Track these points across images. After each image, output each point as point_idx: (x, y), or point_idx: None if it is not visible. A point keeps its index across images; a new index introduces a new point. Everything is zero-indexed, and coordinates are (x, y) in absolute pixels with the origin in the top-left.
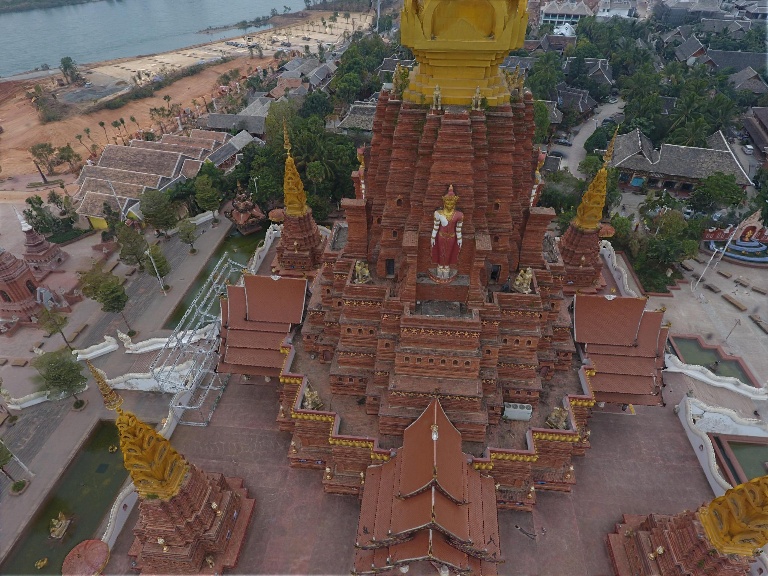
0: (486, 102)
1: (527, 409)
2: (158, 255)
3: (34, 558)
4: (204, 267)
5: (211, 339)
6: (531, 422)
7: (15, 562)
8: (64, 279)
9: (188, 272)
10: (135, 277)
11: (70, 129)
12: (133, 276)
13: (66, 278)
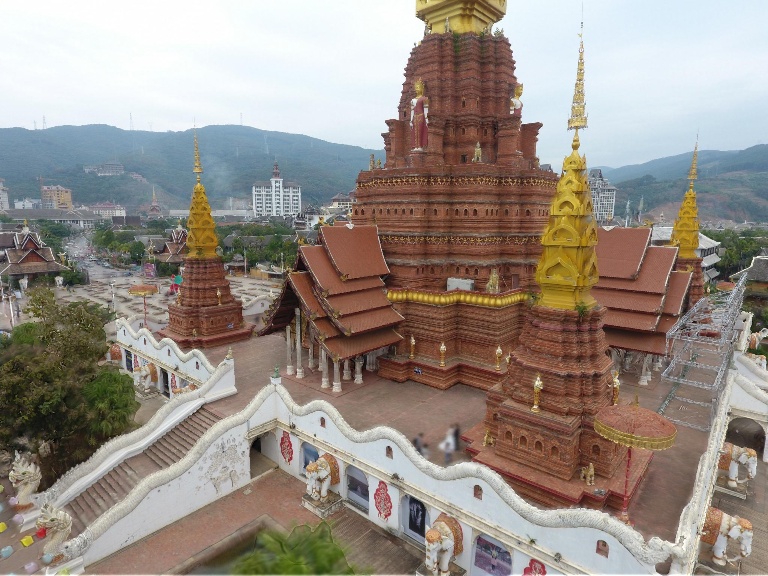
0: None
1: None
2: None
3: None
4: None
5: (722, 353)
6: None
7: None
8: None
9: None
10: None
11: None
12: None
13: None
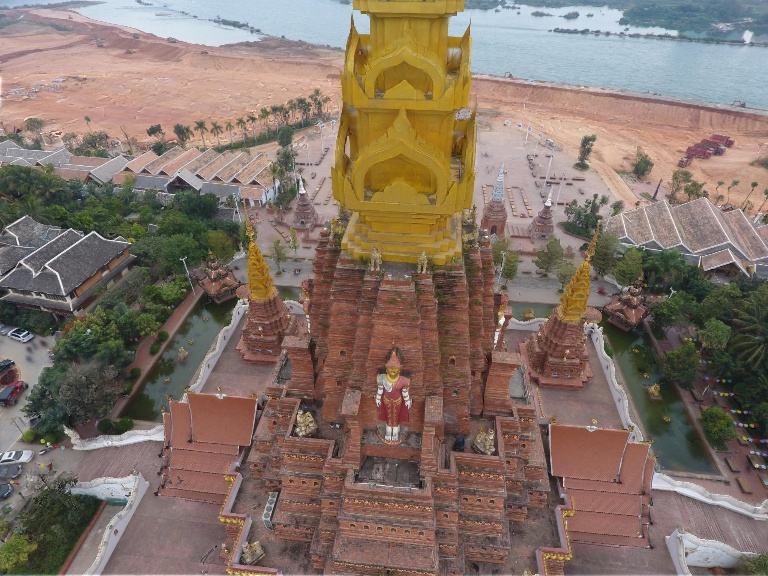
0: (339, 238)
1: (265, 513)
2: (511, 262)
3: (291, 296)
4: (543, 304)
5: None
6: (264, 529)
7: (291, 291)
8: (525, 246)
9: (530, 295)
10: (535, 276)
11: (763, 179)
12: (536, 275)
13: (527, 246)
